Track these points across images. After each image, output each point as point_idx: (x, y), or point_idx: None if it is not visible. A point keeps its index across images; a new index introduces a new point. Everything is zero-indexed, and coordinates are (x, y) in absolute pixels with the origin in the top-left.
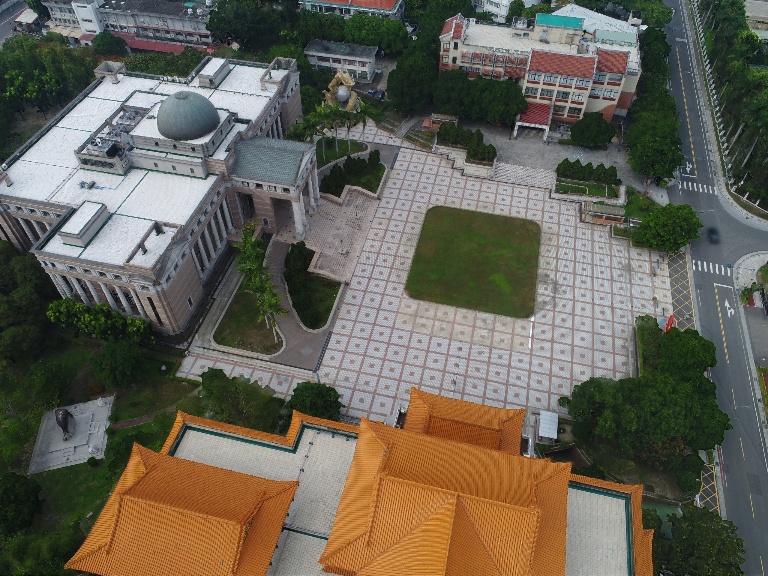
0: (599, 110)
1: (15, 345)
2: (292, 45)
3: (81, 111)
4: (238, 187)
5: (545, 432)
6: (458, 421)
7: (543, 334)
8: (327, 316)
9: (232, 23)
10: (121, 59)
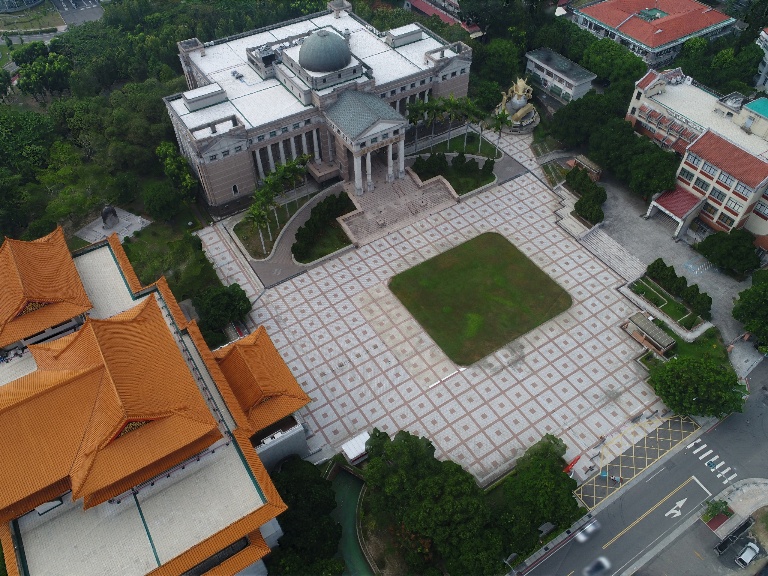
0: (763, 234)
1: (132, 157)
2: (512, 43)
3: (294, 28)
4: (328, 125)
5: (348, 447)
6: (246, 363)
7: (455, 386)
8: (316, 258)
9: (473, 5)
10: (390, 9)
